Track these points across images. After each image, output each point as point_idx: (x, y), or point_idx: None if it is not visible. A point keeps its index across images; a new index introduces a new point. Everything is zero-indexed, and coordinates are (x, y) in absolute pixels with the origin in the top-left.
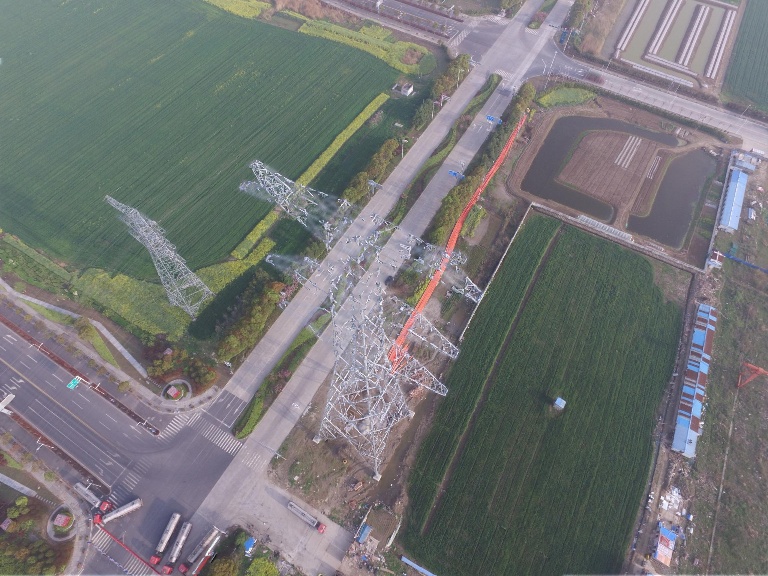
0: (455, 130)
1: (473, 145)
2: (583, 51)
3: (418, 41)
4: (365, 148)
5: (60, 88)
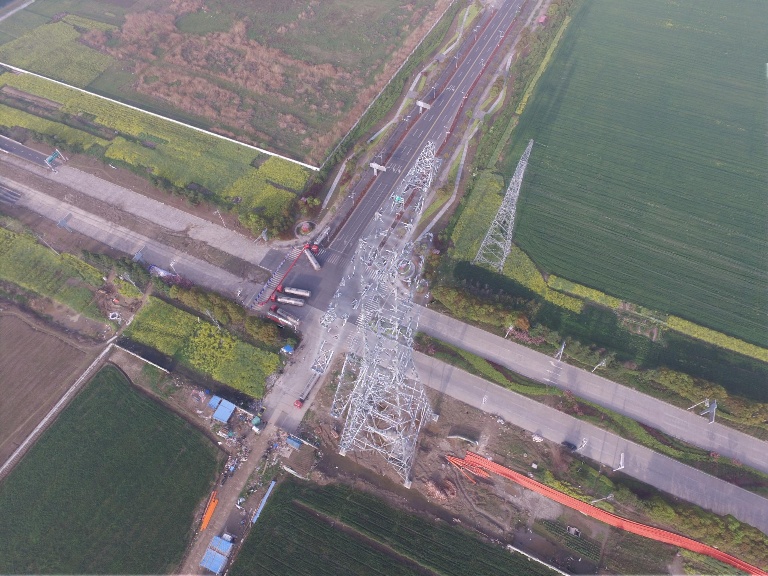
0: None
1: None
2: None
3: None
4: None
5: (695, 88)
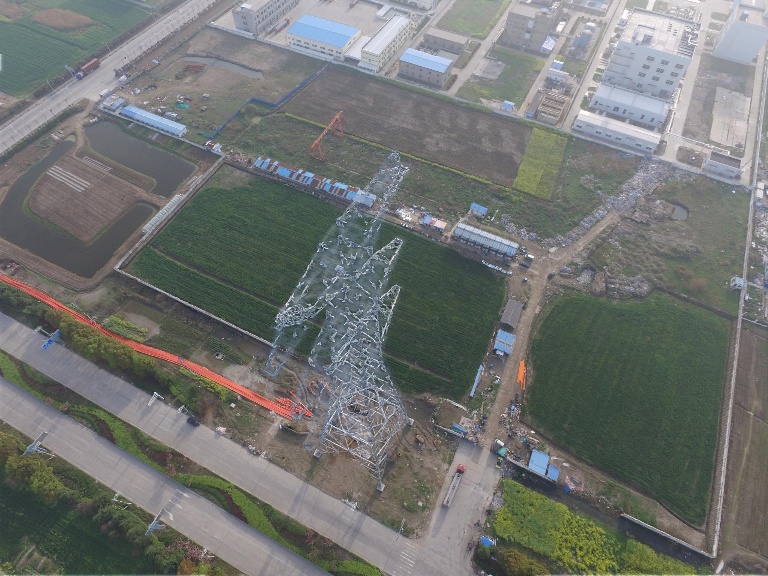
0: None
1: None
2: None
3: None
4: None
5: None
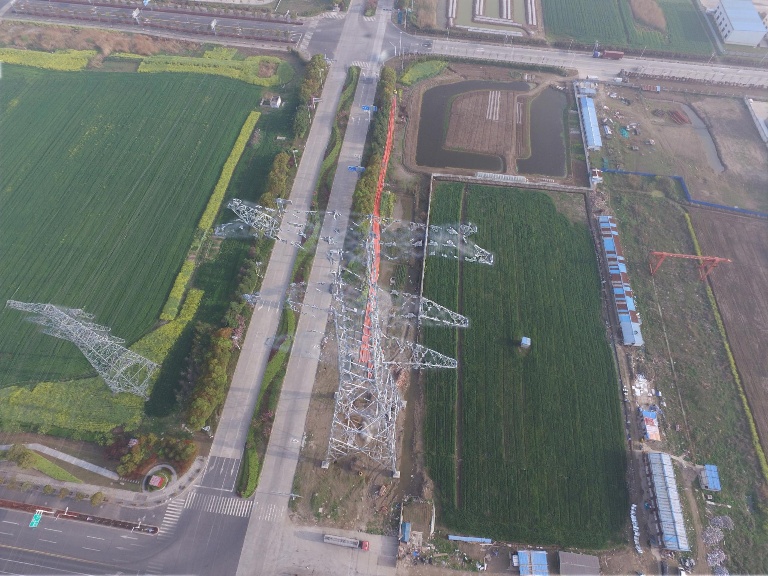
0: (337, 128)
1: (359, 137)
2: (421, 26)
3: (267, 53)
4: (257, 169)
5: None
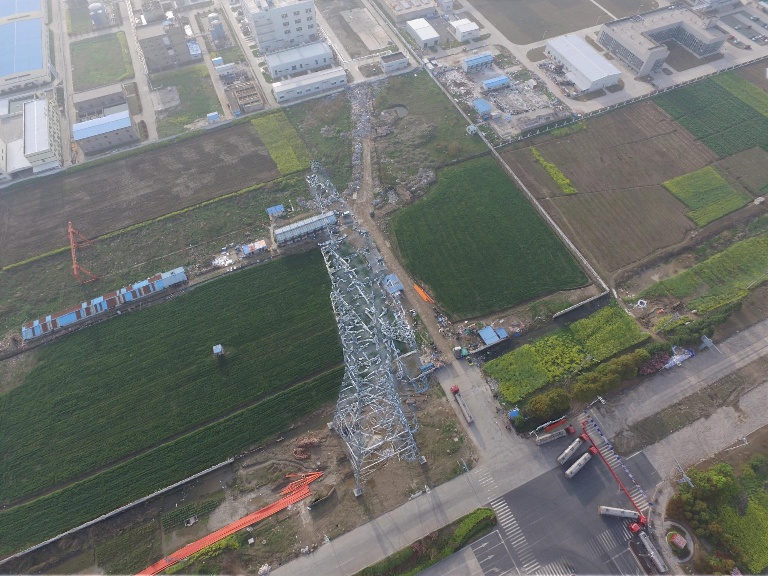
0: None
1: None
2: None
3: None
4: None
5: None
